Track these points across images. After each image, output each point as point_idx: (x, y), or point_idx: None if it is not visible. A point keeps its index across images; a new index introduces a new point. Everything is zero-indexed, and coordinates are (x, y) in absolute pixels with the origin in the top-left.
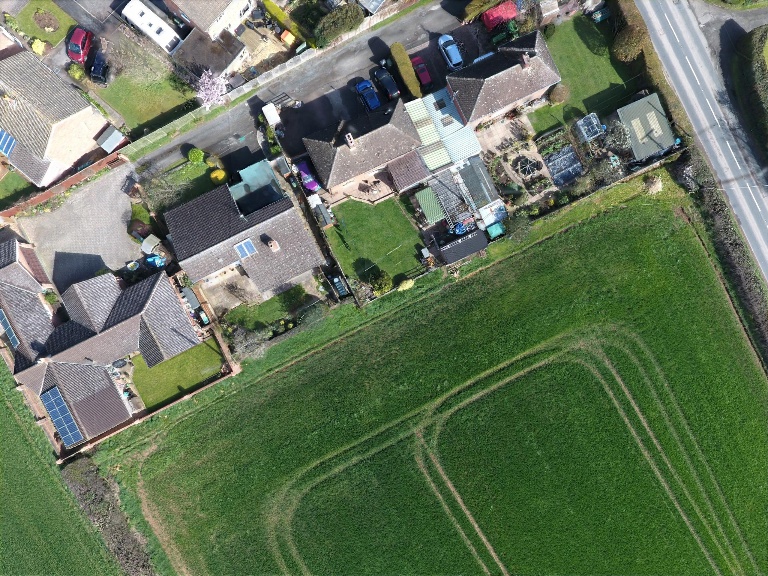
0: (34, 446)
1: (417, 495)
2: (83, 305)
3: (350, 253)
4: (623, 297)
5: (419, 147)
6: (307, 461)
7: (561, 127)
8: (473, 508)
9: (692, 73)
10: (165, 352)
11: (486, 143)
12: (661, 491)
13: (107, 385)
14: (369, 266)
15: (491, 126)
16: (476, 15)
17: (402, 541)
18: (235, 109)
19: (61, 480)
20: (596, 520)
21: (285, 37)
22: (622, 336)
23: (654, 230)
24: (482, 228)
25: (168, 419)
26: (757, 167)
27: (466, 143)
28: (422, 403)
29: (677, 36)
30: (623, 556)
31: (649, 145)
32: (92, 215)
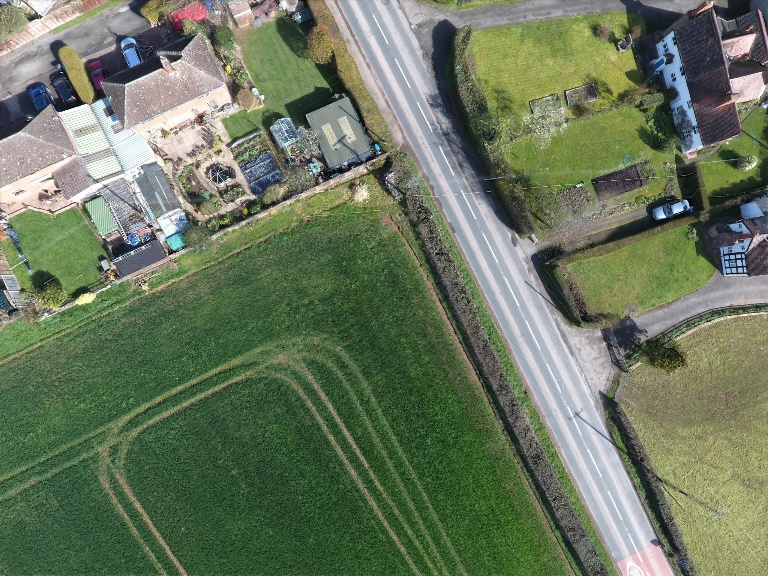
0: None
1: (100, 517)
2: None
3: None
4: (326, 309)
5: (82, 155)
6: None
7: (257, 133)
8: (163, 530)
9: (402, 76)
10: None
11: (176, 150)
12: (368, 510)
13: None
14: (48, 279)
15: (180, 132)
16: (158, 17)
17: (85, 565)
18: None
19: None
20: (297, 541)
21: None
22: (325, 350)
23: (359, 239)
24: (162, 239)
25: None
26: (472, 173)
27: (138, 151)
28: (106, 421)
29: (386, 37)
30: None
31: (342, 151)
32: None
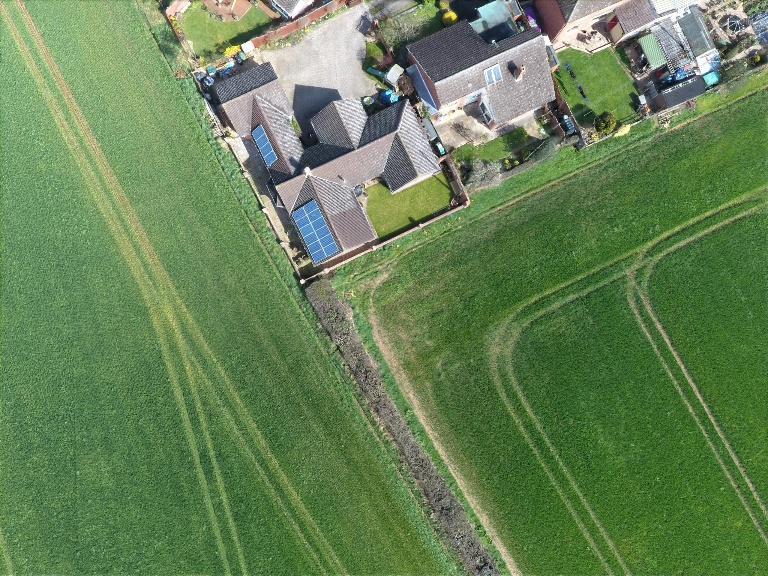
0: (275, 268)
1: (629, 334)
2: (342, 121)
3: (569, 99)
4: None
5: None
6: (528, 295)
7: None
8: (681, 349)
9: None
10: (418, 170)
11: None
12: None
13: (354, 205)
14: (587, 112)
15: None
16: None
17: (615, 377)
18: None
19: (300, 302)
20: None
21: None
22: None
23: None
24: None
25: (400, 249)
26: None
27: None
28: (635, 245)
29: None
30: None
31: None
32: (329, 51)
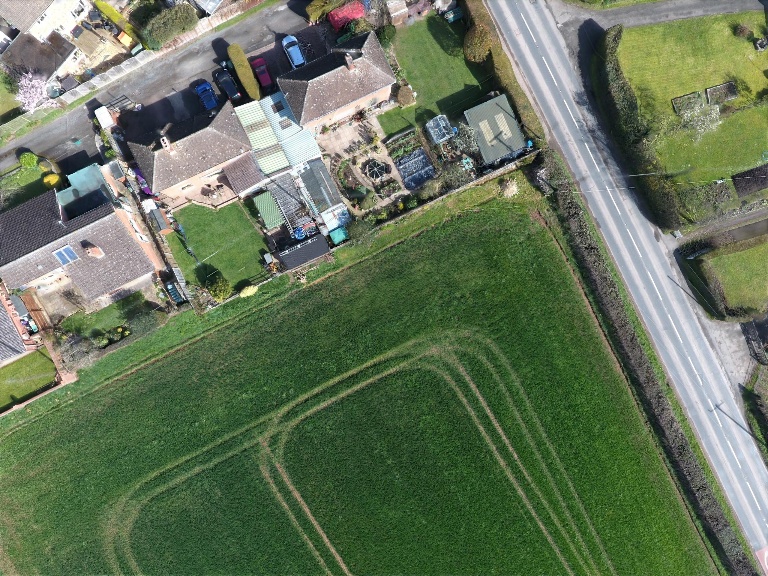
0: None
1: (262, 505)
2: None
3: (192, 259)
4: (477, 302)
5: (253, 150)
6: (146, 471)
7: (412, 129)
8: (321, 518)
9: (549, 74)
10: None
11: (334, 146)
12: (517, 500)
13: None
14: (211, 272)
15: (338, 129)
16: (320, 15)
17: (246, 552)
18: (73, 112)
19: None
20: (449, 530)
21: (121, 38)
22: (476, 342)
23: (509, 234)
24: (325, 233)
25: (0, 429)
26: (617, 169)
27: (305, 146)
28: (267, 411)
29: (534, 36)
30: (477, 566)
31: (498, 147)
32: None
